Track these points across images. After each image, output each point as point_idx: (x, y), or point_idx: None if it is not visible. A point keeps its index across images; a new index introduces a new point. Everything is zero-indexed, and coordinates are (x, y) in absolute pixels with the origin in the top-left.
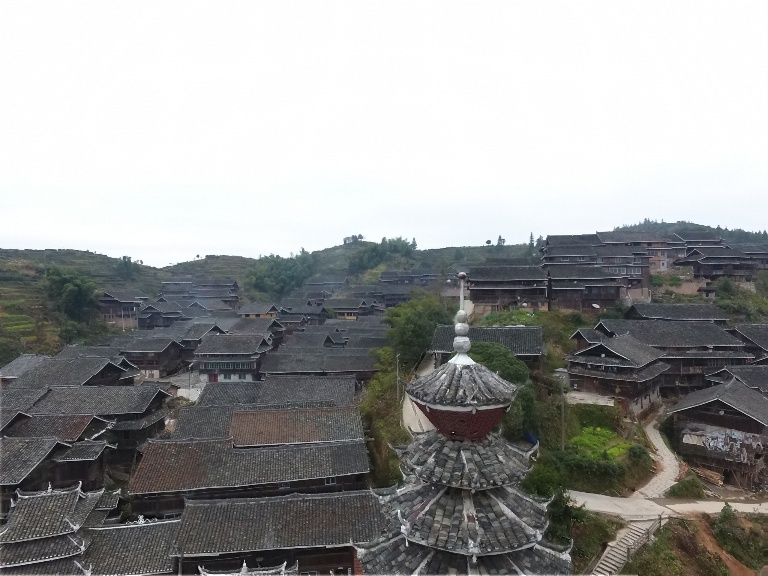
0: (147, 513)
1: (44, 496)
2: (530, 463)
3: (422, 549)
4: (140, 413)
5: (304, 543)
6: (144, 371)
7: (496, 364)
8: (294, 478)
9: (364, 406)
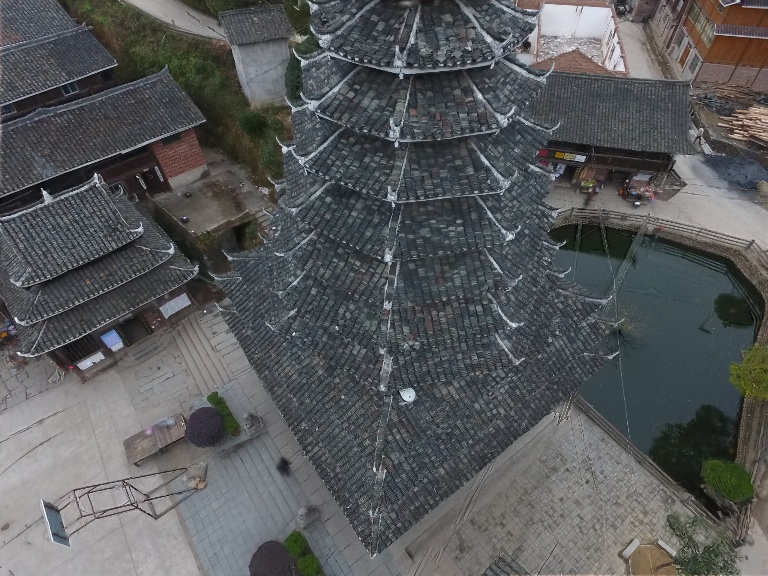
0: None
1: None
2: (294, 14)
3: (402, 9)
4: None
5: (93, 157)
6: None
7: None
8: (17, 96)
9: None
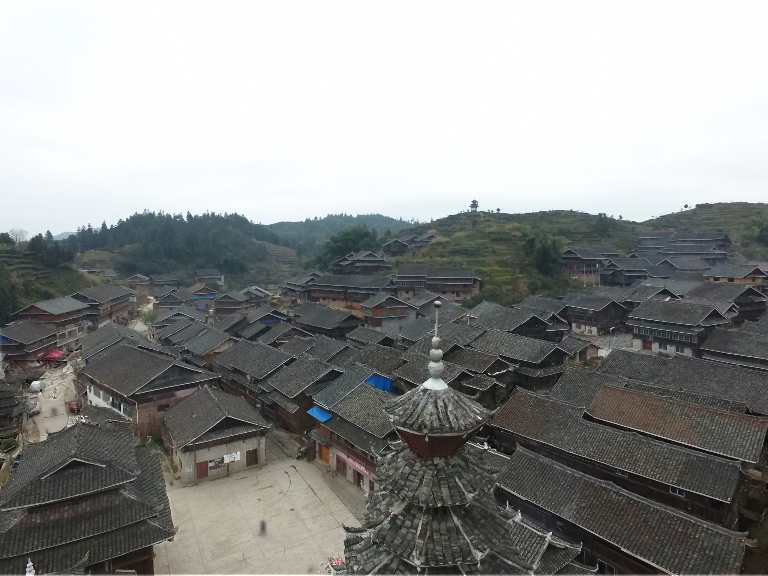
0: (504, 444)
1: None
2: None
3: None
4: (536, 364)
5: (599, 532)
6: (584, 326)
7: None
8: (628, 469)
9: None
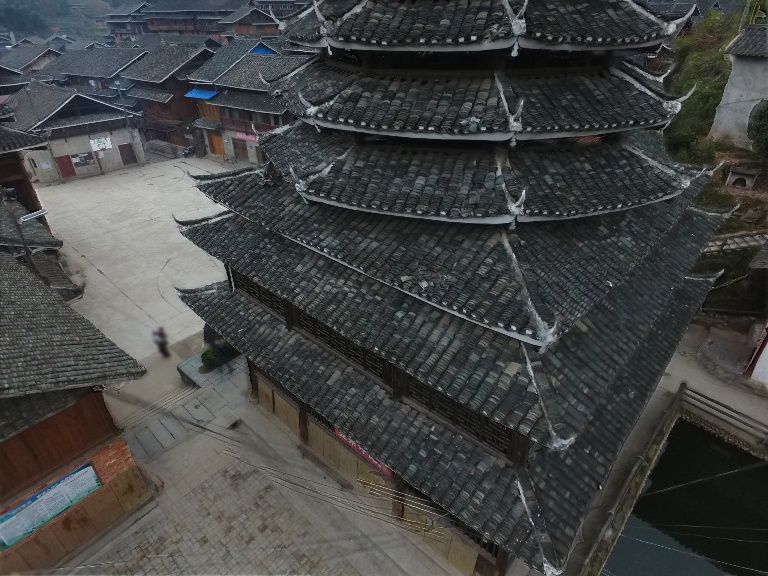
0: None
1: None
2: None
3: None
4: None
5: None
6: None
7: None
8: None
9: (683, 39)
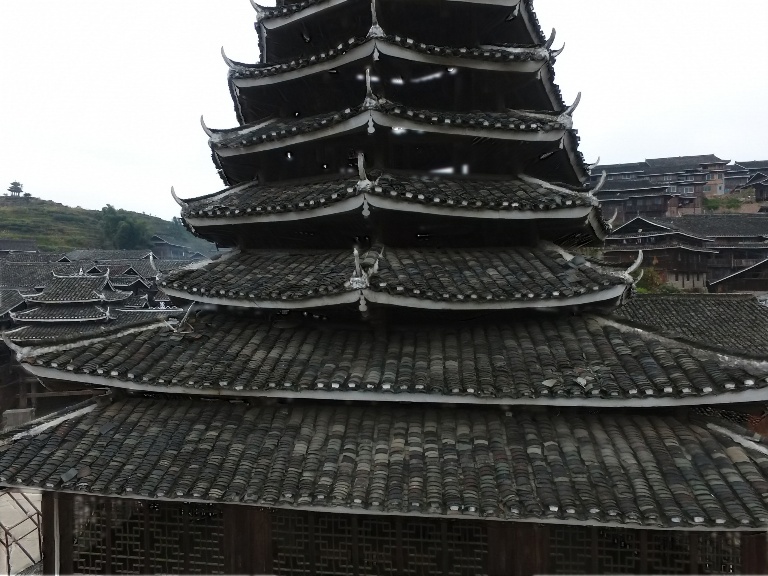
0: None
1: (76, 277)
2: None
3: None
4: None
5: None
6: None
7: None
8: None
9: None
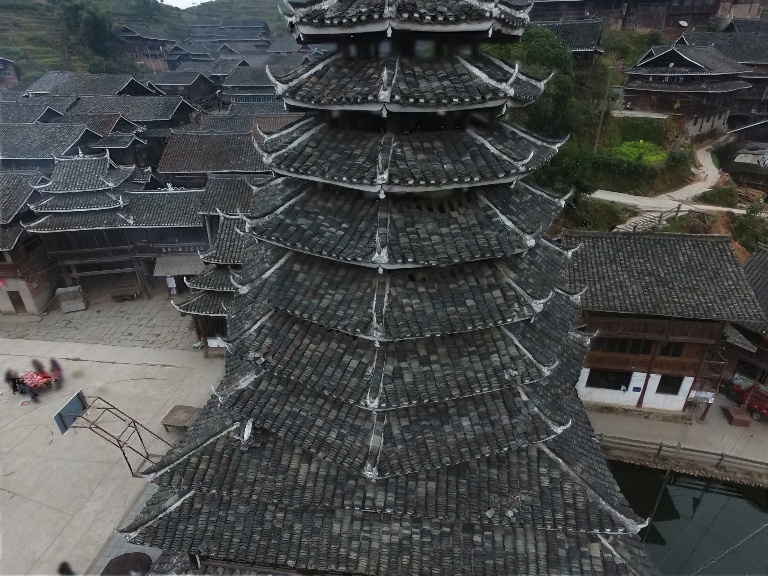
0: None
1: (78, 160)
2: None
3: None
4: (167, 120)
5: None
6: None
7: (534, 45)
8: None
9: None
